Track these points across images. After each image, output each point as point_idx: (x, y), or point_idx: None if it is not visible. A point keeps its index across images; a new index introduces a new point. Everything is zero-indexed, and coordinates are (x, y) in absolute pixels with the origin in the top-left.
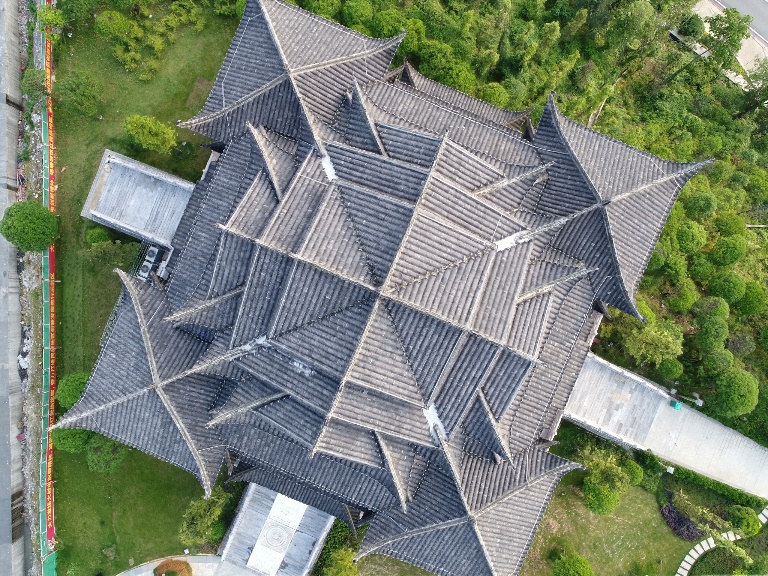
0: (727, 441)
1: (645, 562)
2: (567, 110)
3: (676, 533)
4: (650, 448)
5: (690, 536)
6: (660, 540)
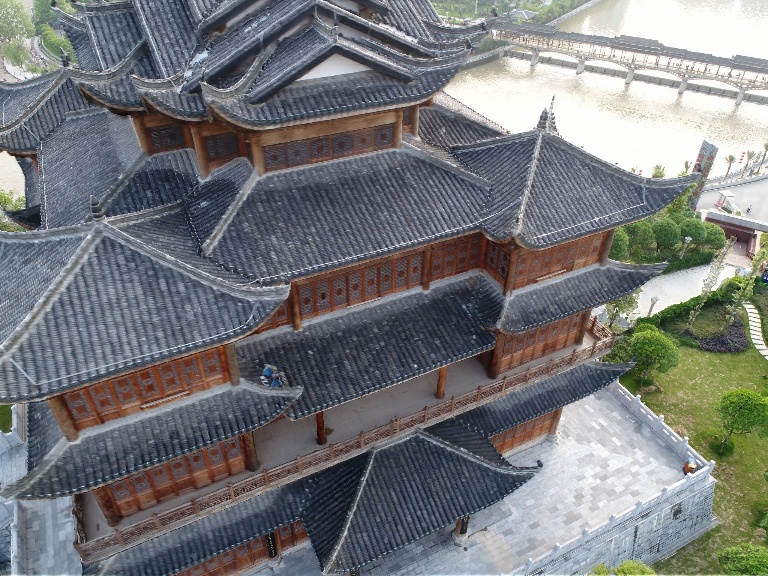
0: (654, 286)
1: (761, 387)
2: None
3: (734, 351)
4: None
5: (742, 344)
6: (738, 366)
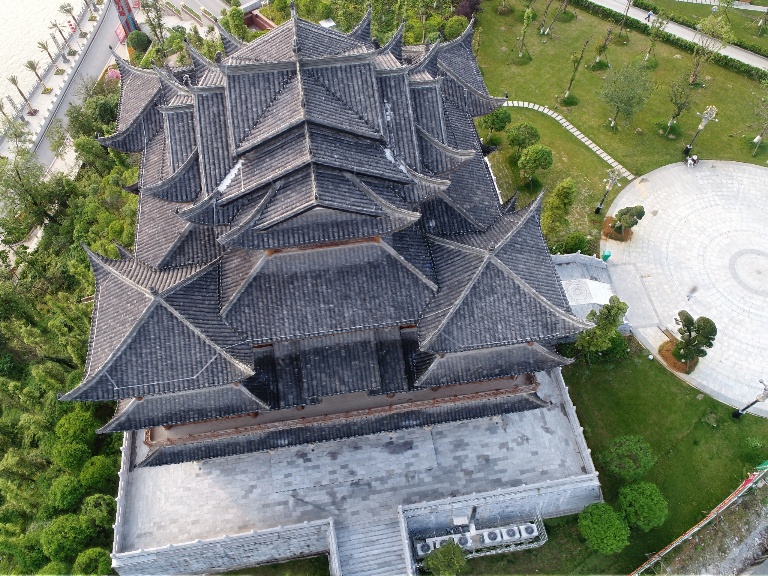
0: None
1: None
2: None
3: None
4: None
5: None
6: None
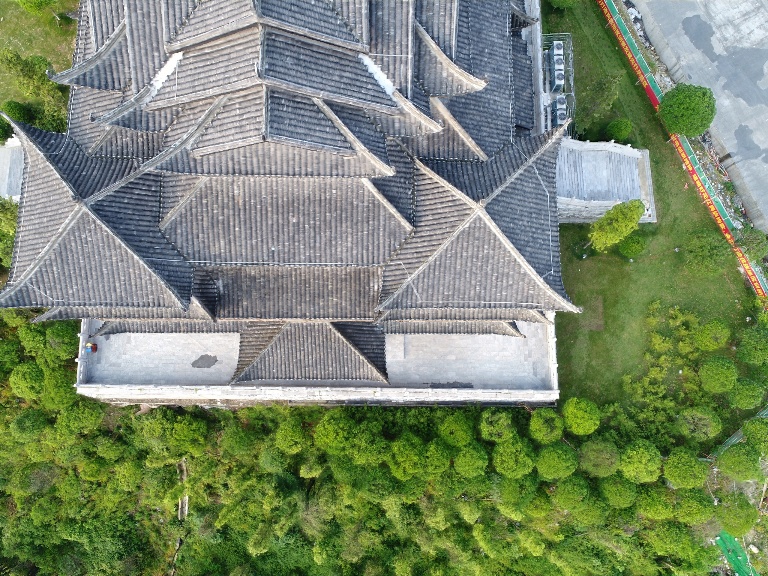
0: None
1: None
2: (210, 466)
3: None
4: (4, 149)
5: None
6: None
